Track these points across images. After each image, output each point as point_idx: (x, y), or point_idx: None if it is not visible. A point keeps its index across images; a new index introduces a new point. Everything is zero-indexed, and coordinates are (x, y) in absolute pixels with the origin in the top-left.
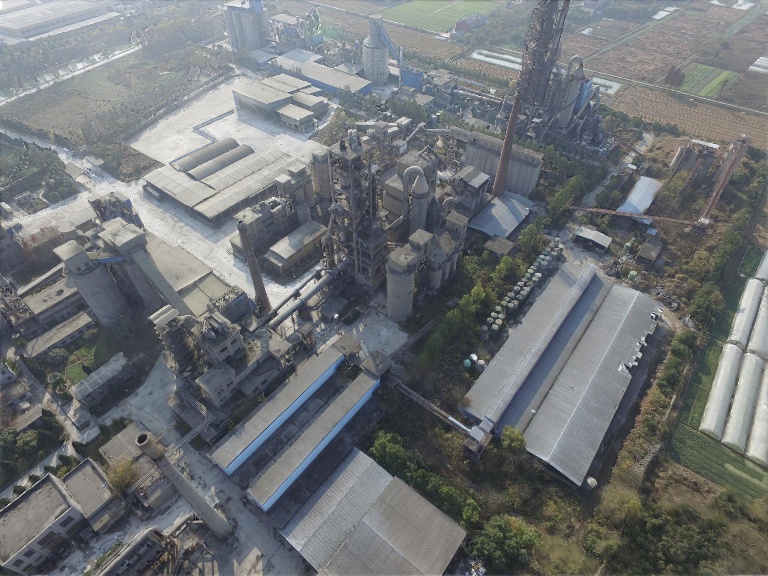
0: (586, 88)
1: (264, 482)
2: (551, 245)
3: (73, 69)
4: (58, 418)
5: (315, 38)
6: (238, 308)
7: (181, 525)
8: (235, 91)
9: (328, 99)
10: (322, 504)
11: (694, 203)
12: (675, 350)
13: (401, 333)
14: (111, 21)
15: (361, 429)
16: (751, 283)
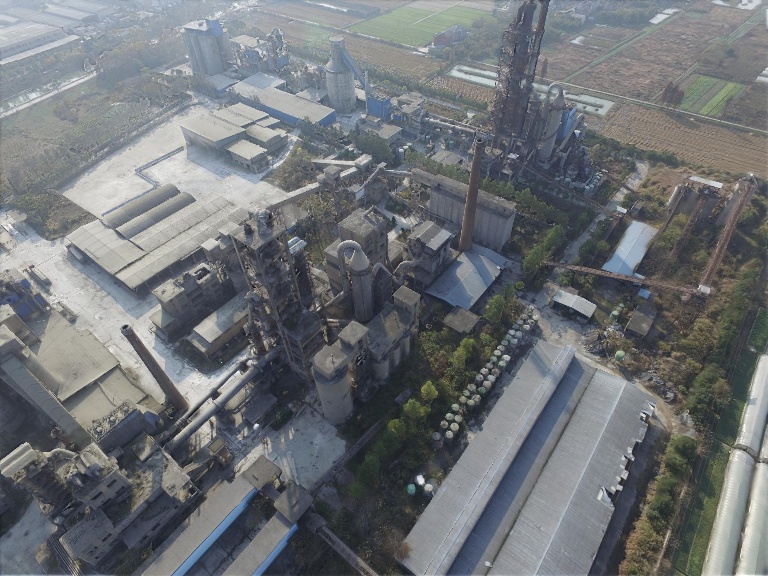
0: (569, 117)
1: None
2: (524, 316)
3: (24, 100)
4: None
5: (279, 60)
6: (130, 428)
7: None
8: (183, 127)
9: (287, 131)
10: None
11: (694, 253)
12: (670, 464)
13: (338, 440)
14: (69, 45)
15: None
16: (763, 361)
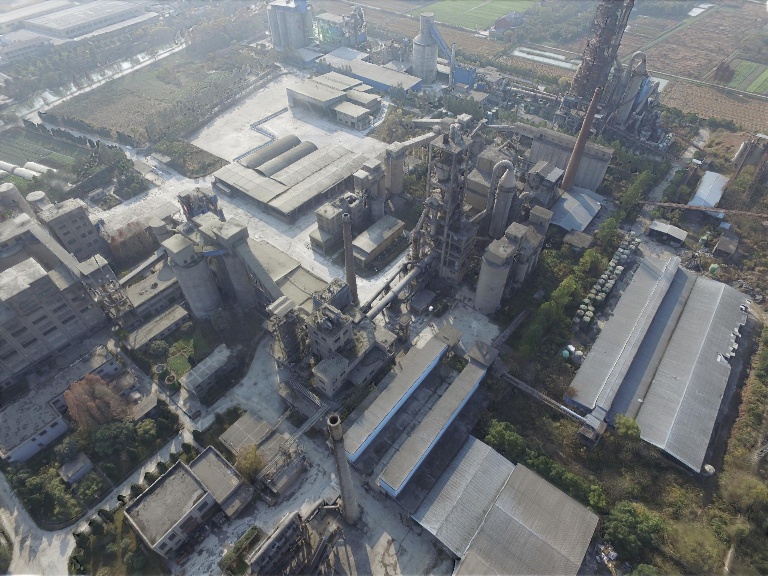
0: (645, 84)
1: (394, 468)
2: (628, 239)
3: (118, 69)
4: (169, 408)
5: (359, 36)
6: (340, 300)
7: (314, 510)
8: (290, 89)
9: (380, 97)
10: (449, 490)
11: (762, 197)
12: None
13: (491, 325)
14: (151, 21)
15: (474, 418)
16: None
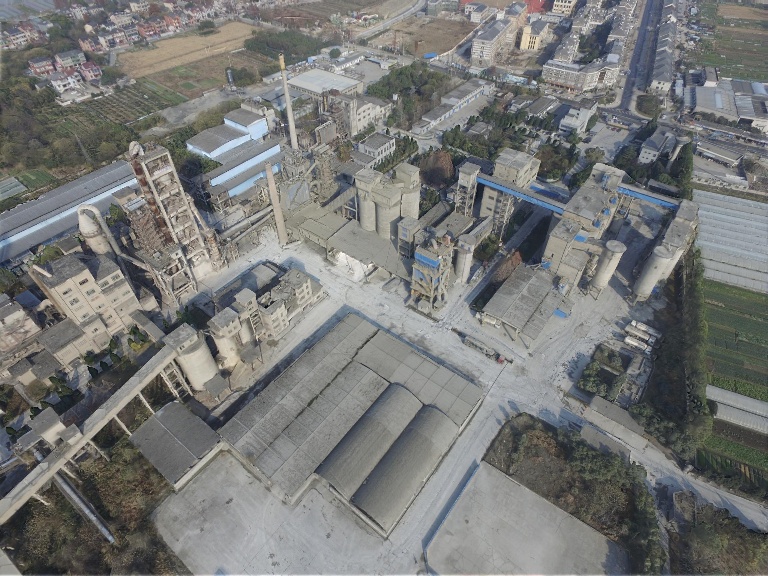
0: None
1: (271, 145)
2: None
3: None
4: None
5: None
6: None
7: None
8: None
9: None
10: None
11: None
12: None
13: None
14: None
15: None
16: None
